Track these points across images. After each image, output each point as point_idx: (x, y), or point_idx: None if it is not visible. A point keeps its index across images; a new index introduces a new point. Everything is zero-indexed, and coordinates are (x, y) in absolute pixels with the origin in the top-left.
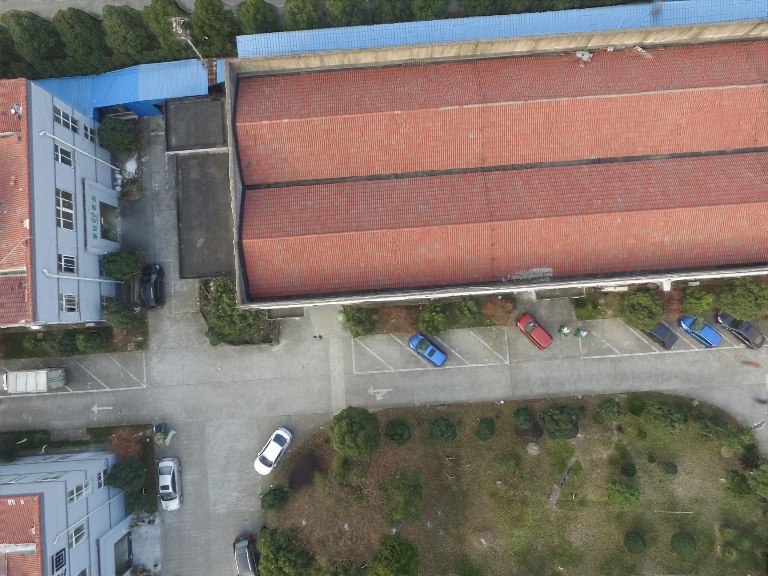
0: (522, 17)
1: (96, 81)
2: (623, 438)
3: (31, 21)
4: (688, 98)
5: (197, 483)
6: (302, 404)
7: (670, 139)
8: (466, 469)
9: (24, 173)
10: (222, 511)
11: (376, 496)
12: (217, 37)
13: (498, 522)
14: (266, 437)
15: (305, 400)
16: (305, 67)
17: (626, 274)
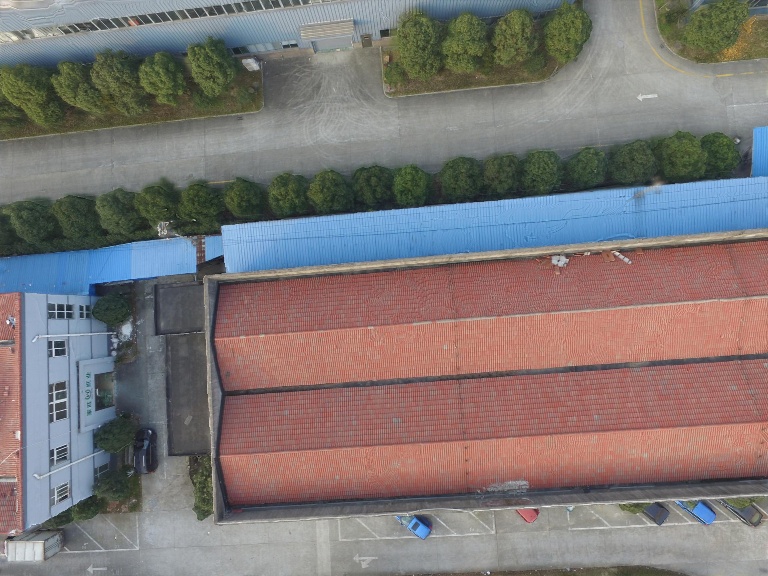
0: (501, 204)
1: (93, 256)
2: None
3: (30, 212)
4: (666, 312)
5: None
6: (289, 570)
7: (649, 348)
8: None
9: (16, 386)
10: None
11: None
12: (205, 219)
13: None
14: None
15: (291, 566)
16: (283, 274)
17: (605, 487)
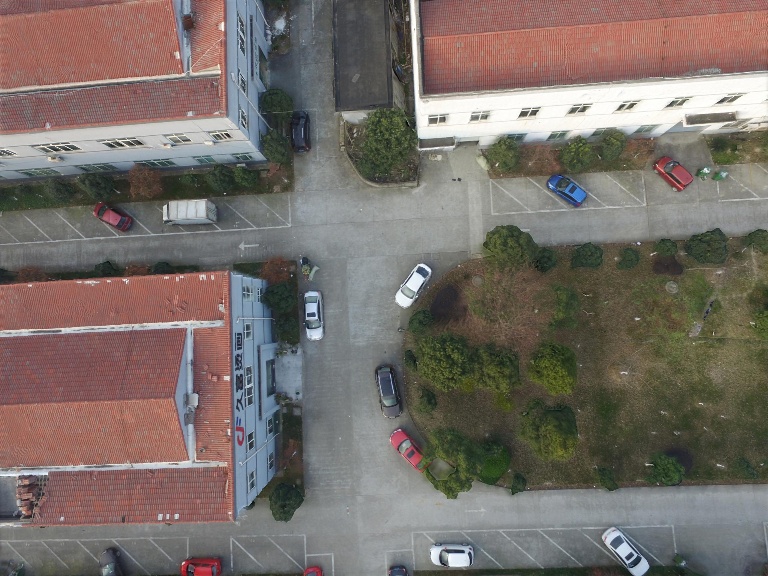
0: None
1: None
2: (763, 278)
3: None
4: None
5: (338, 317)
6: (441, 243)
7: None
8: (604, 306)
9: None
10: (362, 343)
11: (514, 330)
12: None
13: (636, 357)
14: (405, 274)
15: (444, 239)
16: None
17: None
